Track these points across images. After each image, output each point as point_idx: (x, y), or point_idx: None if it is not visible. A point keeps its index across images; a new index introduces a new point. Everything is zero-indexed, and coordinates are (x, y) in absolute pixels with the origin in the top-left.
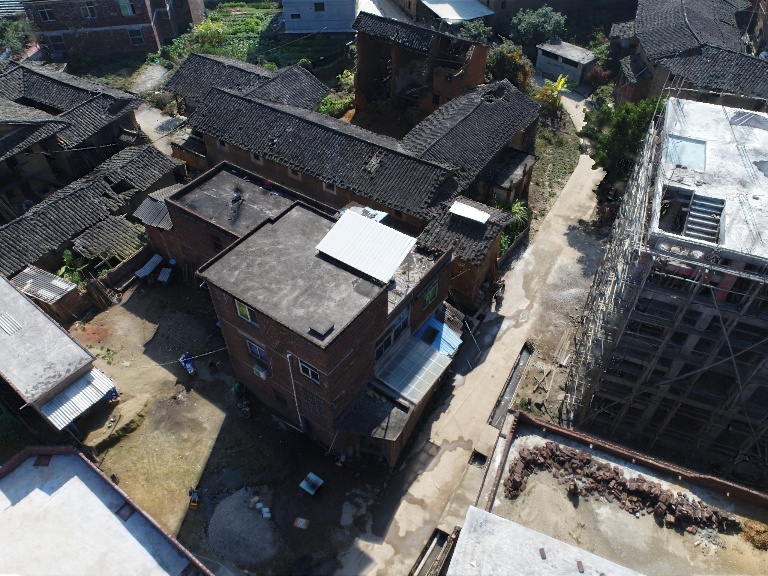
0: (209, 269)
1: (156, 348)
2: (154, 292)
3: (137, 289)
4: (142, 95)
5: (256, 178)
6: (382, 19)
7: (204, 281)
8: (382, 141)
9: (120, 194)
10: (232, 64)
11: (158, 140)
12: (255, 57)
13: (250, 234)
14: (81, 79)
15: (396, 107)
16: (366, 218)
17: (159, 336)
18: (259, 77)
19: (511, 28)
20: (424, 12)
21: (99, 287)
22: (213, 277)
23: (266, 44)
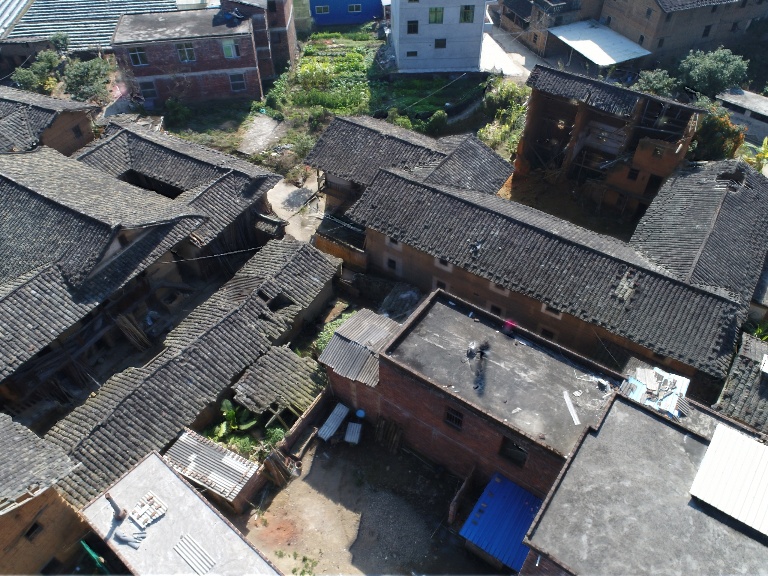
0: (539, 531)
1: (367, 555)
2: (341, 457)
3: (318, 452)
4: (256, 157)
5: (488, 317)
6: (566, 75)
7: (539, 555)
8: (618, 250)
9: (278, 313)
10: (389, 132)
11: (289, 220)
12: (377, 106)
13: (572, 457)
14: (197, 146)
15: (569, 177)
16: (756, 443)
17: (366, 534)
18: (430, 153)
19: (679, 73)
20: (553, 47)
21: (278, 459)
22: (552, 548)
23: (379, 86)
